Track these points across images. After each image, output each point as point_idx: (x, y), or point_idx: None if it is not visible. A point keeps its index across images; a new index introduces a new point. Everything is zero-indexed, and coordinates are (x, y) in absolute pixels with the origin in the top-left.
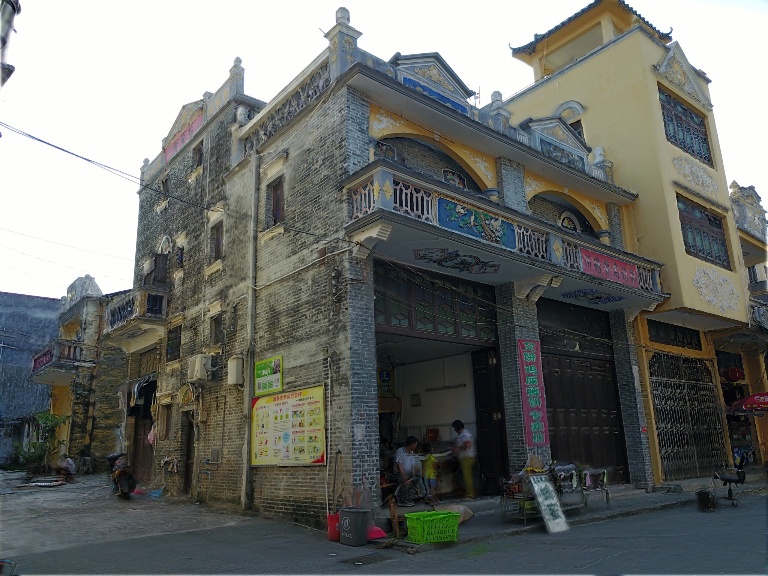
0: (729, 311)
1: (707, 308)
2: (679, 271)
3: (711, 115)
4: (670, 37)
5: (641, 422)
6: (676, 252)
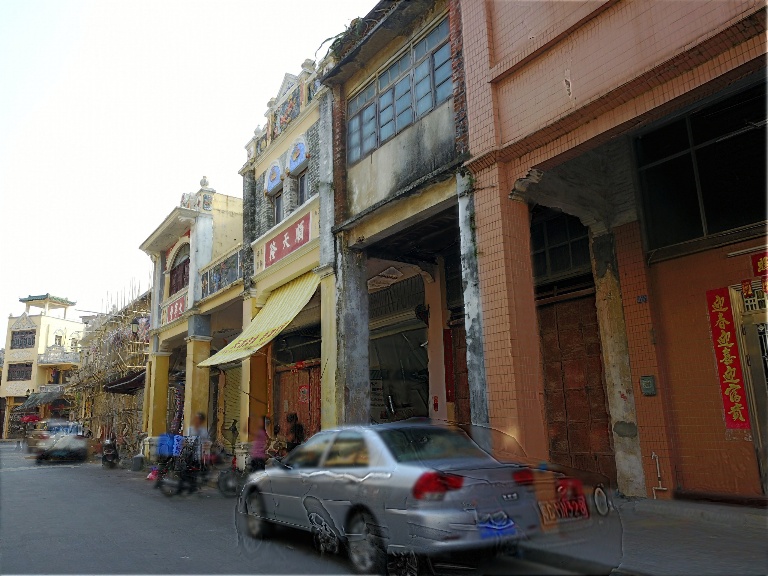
0: (20, 394)
1: (9, 395)
2: (0, 388)
3: (39, 327)
4: (46, 298)
5: (4, 424)
6: (1, 383)
